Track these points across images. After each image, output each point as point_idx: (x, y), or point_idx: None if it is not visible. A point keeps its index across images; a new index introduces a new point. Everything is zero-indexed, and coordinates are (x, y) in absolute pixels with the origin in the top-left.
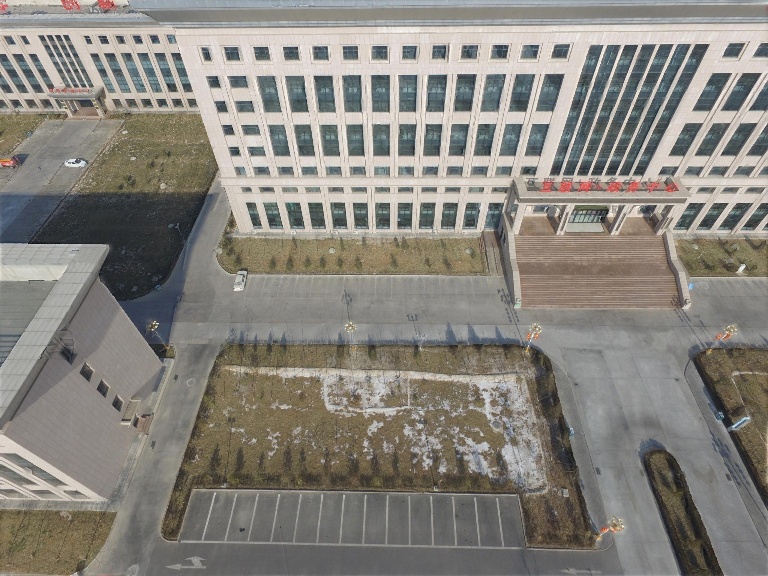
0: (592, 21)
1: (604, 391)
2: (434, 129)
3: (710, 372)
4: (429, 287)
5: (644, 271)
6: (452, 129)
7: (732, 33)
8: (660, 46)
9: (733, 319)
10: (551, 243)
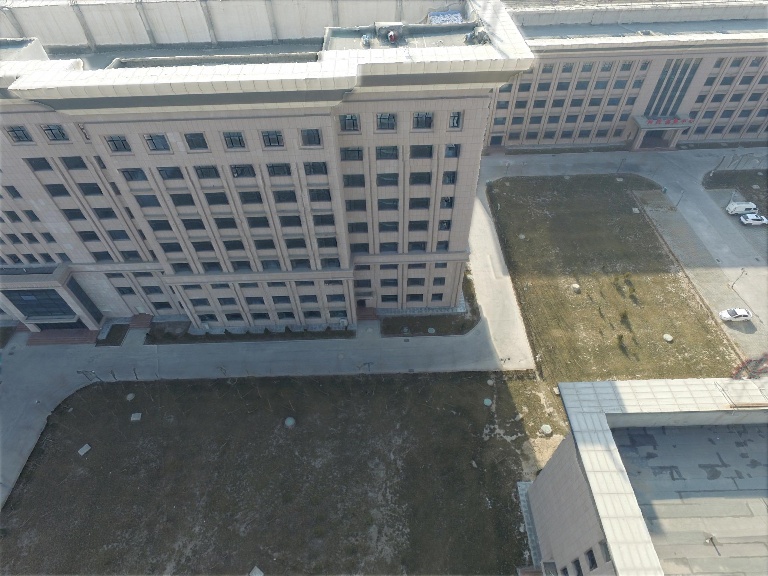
0: None
1: None
2: None
3: None
4: None
5: None
6: None
7: None
8: None
9: None
10: None
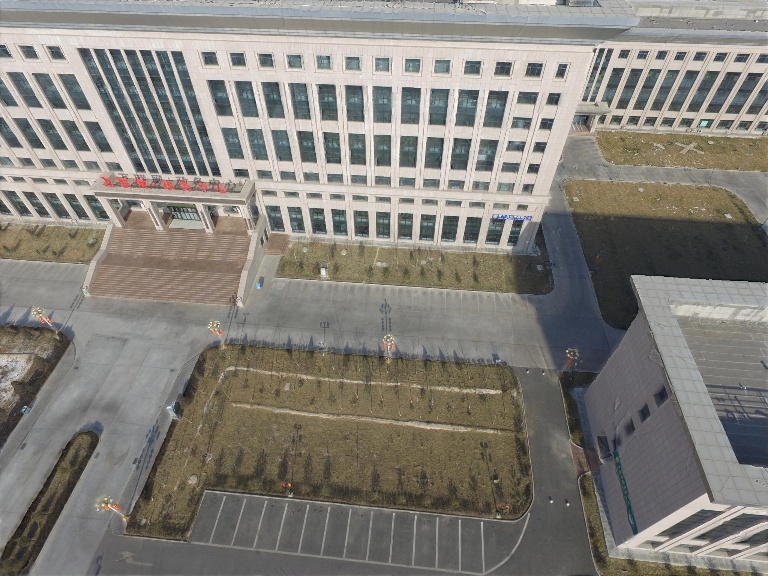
0: (55, 25)
1: (96, 376)
2: (2, 122)
3: (208, 365)
4: (26, 272)
5: (219, 268)
6: (18, 123)
7: (194, 42)
8: (141, 52)
9: (277, 319)
10: (148, 237)
